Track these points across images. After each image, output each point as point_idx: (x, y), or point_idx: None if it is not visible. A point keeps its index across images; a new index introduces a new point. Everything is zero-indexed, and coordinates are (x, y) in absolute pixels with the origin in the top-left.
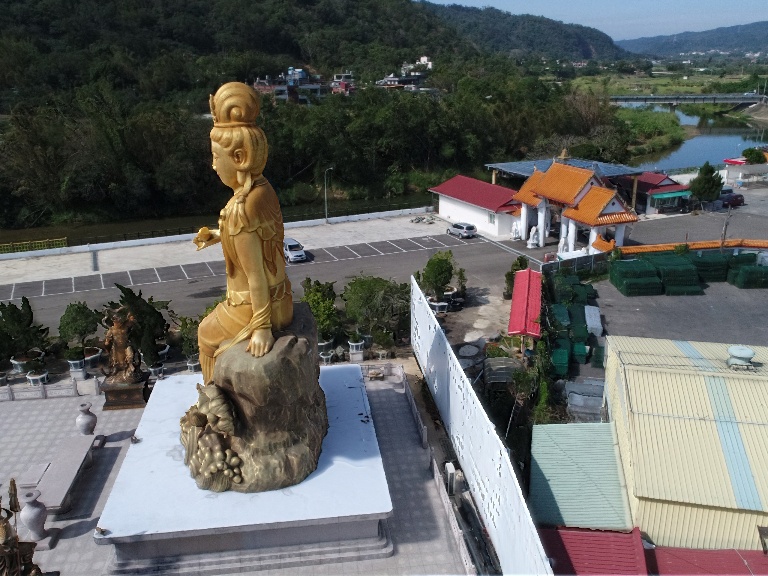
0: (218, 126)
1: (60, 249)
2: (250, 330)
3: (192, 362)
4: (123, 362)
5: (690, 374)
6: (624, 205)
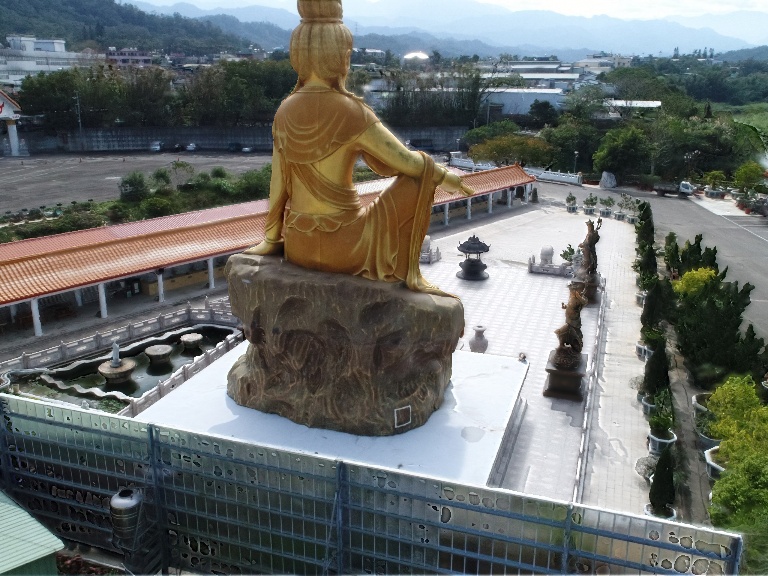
0: None
1: None
2: None
3: None
4: None
5: None
6: None
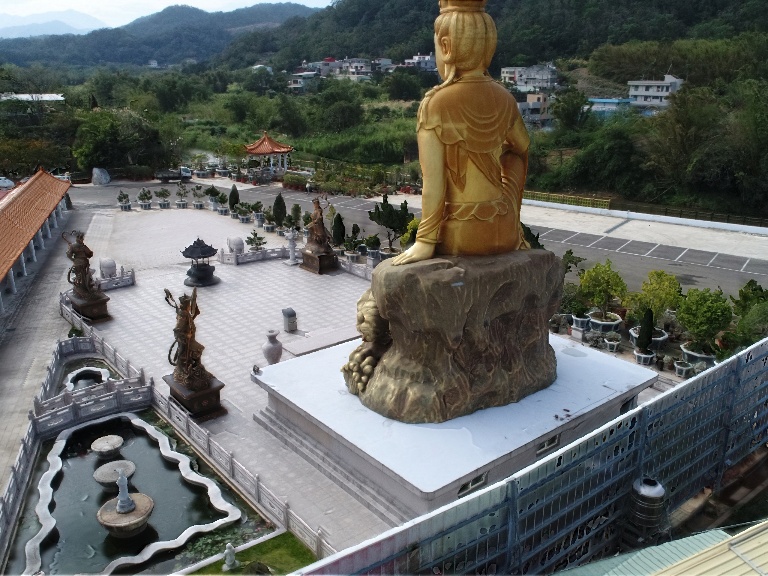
0: None
1: (602, 210)
2: None
3: None
4: None
5: None
6: None
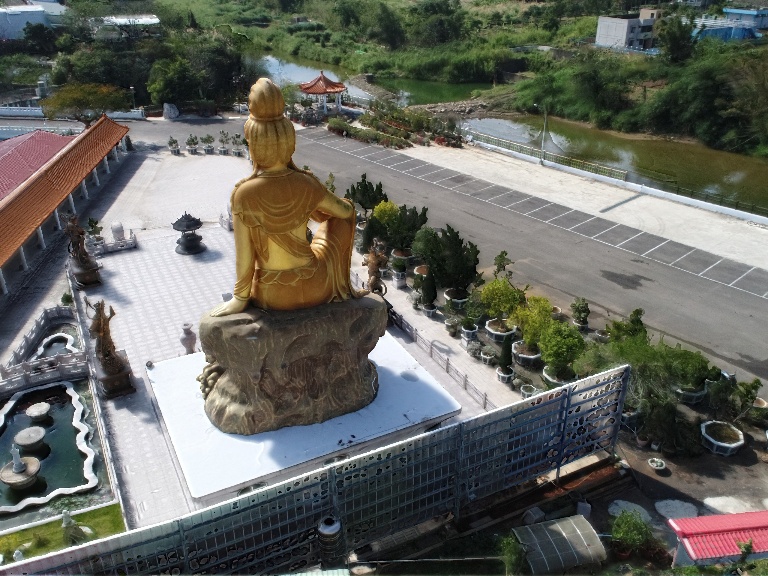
0: None
1: (618, 180)
2: None
3: (450, 320)
4: None
5: None
6: None
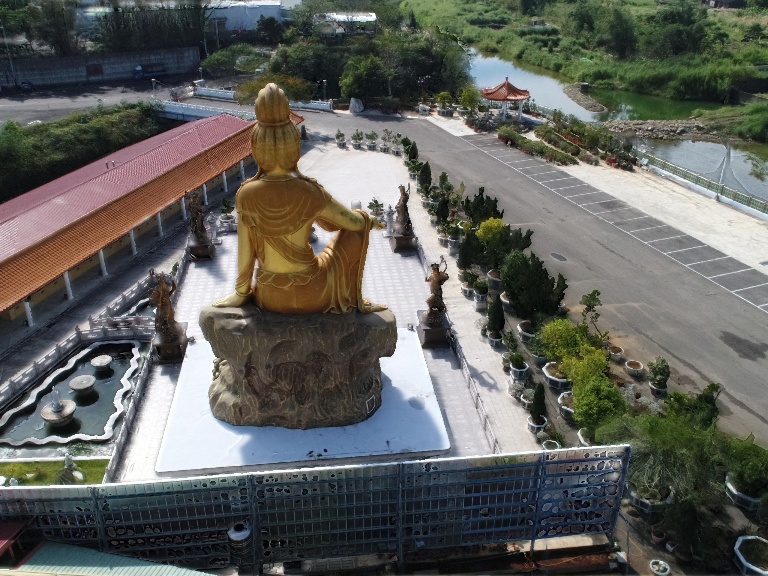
0: None
1: None
2: None
3: None
4: None
5: None
6: None
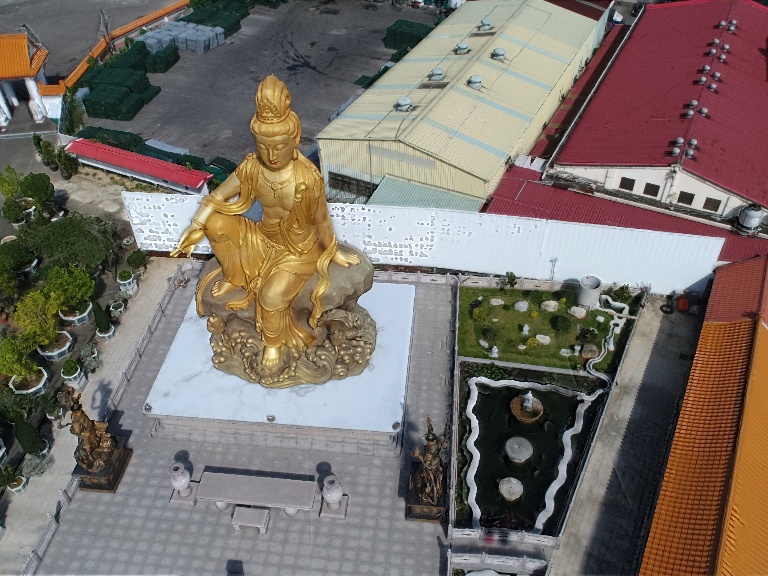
0: (281, 121)
1: None
2: (332, 256)
3: None
4: (96, 441)
5: (417, 124)
6: (34, 44)
